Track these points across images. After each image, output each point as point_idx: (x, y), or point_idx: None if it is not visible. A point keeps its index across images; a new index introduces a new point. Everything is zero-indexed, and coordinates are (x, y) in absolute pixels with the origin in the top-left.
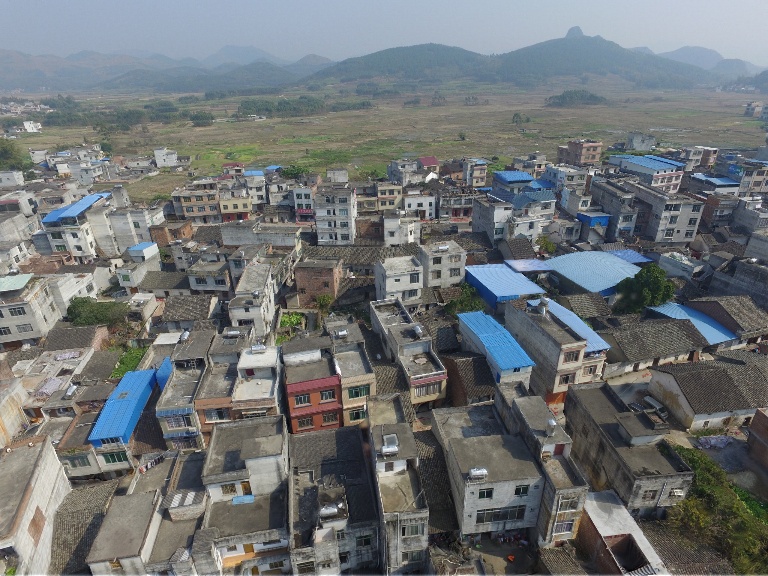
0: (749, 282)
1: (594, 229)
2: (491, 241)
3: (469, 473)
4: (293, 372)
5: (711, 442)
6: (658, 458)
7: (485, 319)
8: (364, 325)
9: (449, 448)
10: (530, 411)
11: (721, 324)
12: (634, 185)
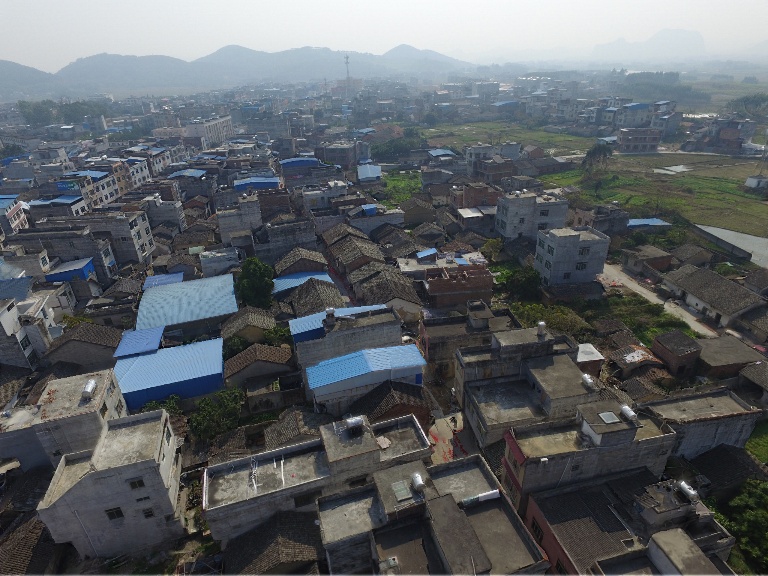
0: (283, 240)
1: (92, 280)
2: (20, 365)
3: (591, 385)
4: (497, 570)
5: (431, 316)
6: (495, 319)
7: (330, 365)
8: (200, 562)
9: (554, 405)
10: (517, 339)
11: (312, 271)
12: (59, 222)
